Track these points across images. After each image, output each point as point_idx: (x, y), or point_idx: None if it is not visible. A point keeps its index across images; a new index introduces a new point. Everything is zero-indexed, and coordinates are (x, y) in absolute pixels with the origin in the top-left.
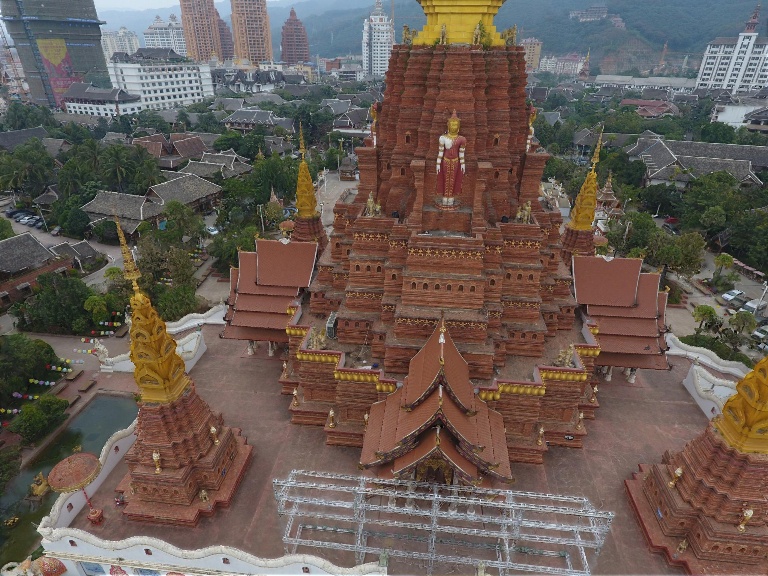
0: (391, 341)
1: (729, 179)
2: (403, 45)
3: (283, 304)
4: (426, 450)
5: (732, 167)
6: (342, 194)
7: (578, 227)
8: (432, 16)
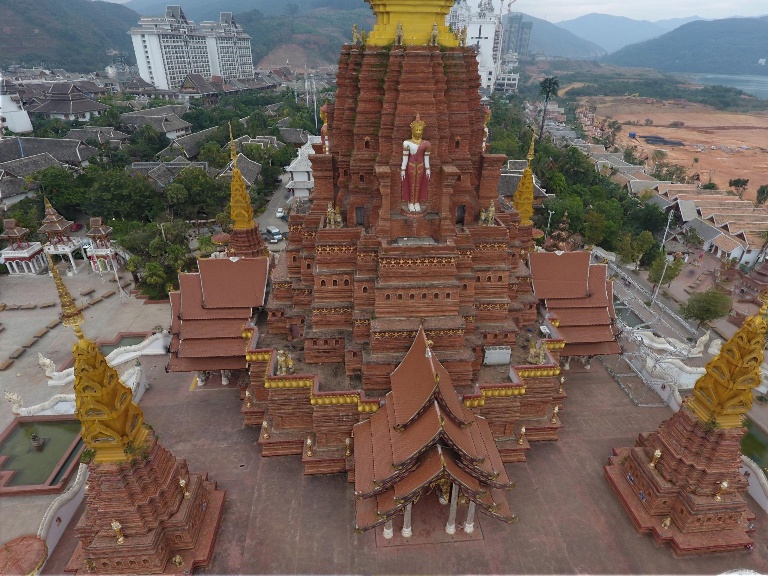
0: (533, 298)
1: (65, 172)
2: (440, 47)
3: (466, 414)
4: (609, 291)
5: (42, 162)
6: (416, 246)
7: (252, 224)
8: (436, 16)
